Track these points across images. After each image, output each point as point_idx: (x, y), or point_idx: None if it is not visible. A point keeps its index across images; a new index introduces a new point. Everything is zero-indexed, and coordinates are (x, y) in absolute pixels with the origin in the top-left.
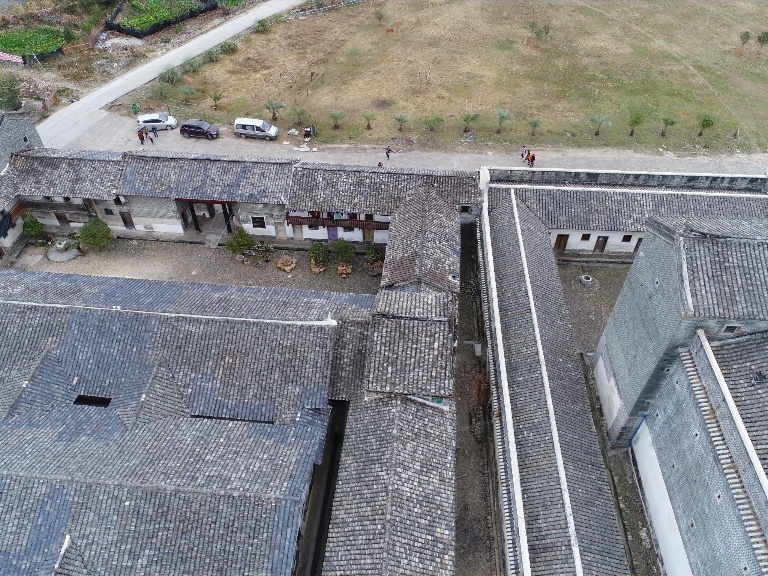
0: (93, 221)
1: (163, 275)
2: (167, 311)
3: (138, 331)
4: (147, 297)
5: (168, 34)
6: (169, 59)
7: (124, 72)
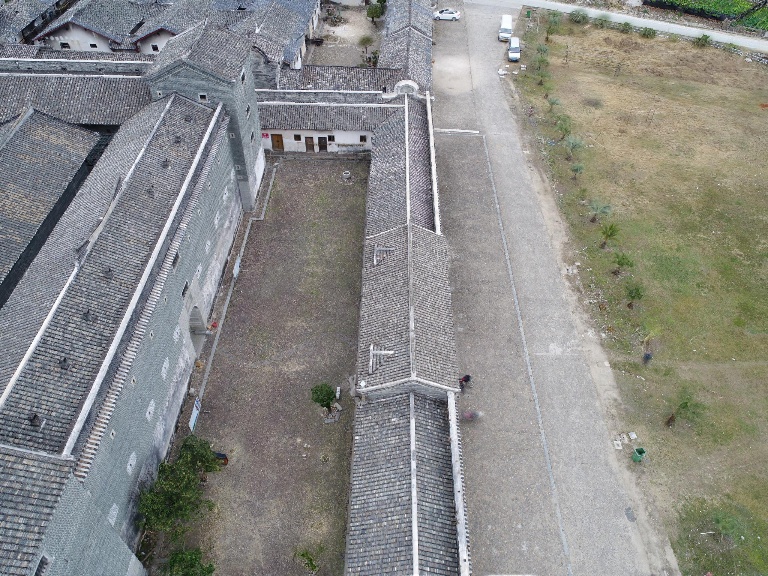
0: (378, 5)
1: (356, 42)
2: (273, 1)
3: (267, 2)
4: (292, 4)
5: (661, 13)
6: (610, 15)
7: (579, 5)
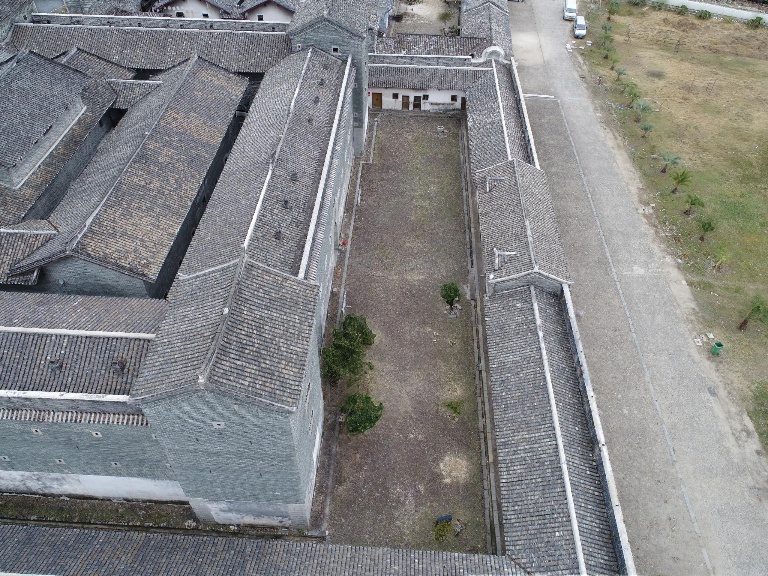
0: None
1: (432, 19)
2: None
3: None
4: None
5: None
6: None
7: None
